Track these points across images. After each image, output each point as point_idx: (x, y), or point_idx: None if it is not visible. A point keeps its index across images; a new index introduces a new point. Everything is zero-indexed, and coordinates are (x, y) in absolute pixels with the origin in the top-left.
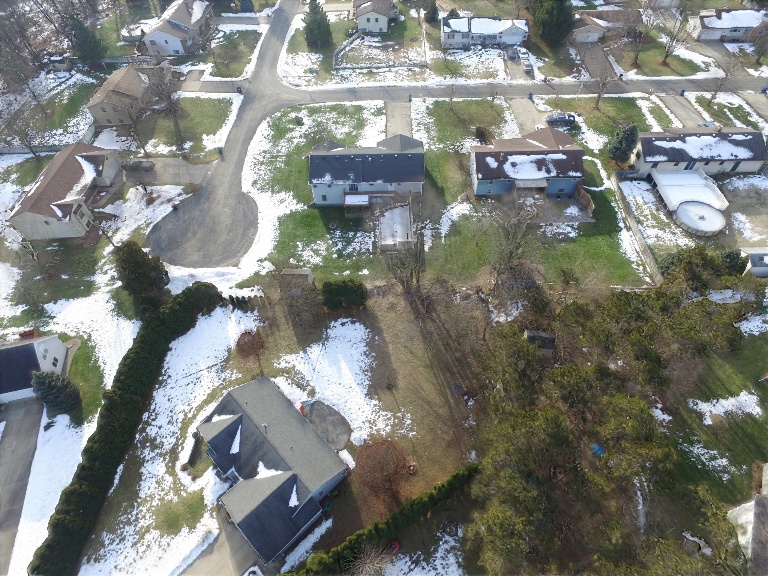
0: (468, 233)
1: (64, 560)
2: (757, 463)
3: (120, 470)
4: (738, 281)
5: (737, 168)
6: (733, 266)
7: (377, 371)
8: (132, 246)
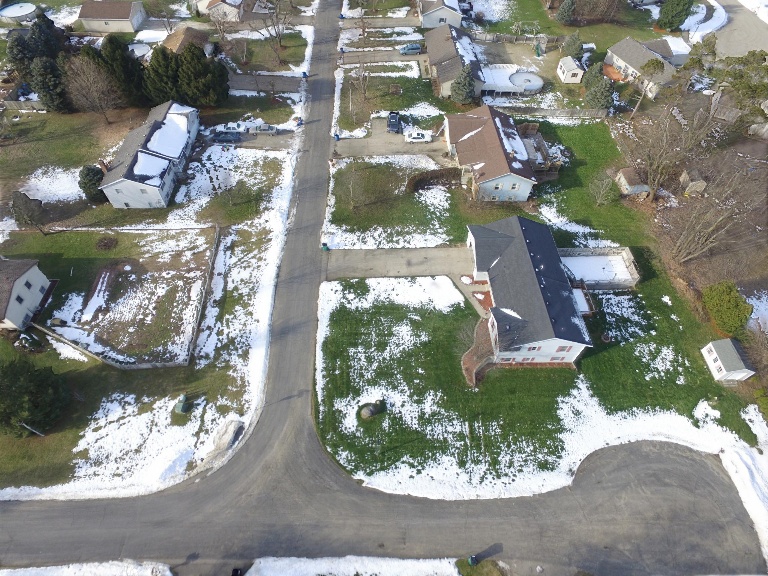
0: None
1: None
2: None
3: None
4: None
5: None
6: None
7: None
8: None
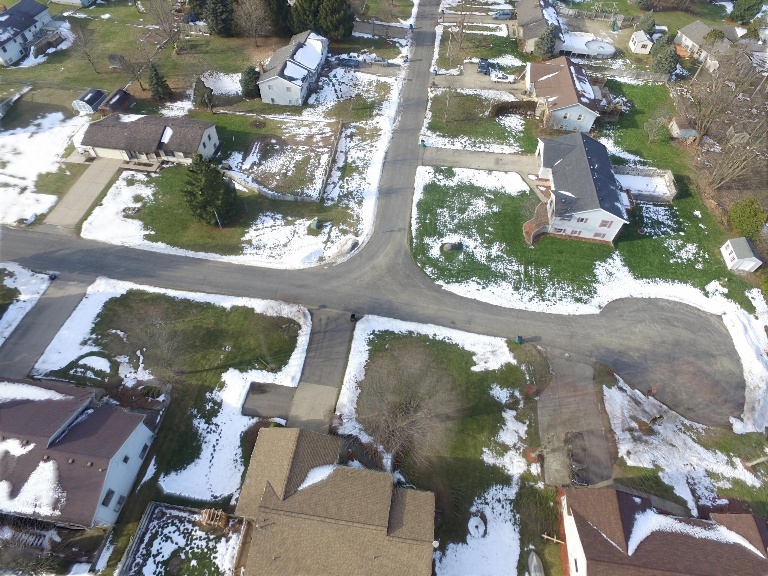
0: None
1: None
2: (765, 93)
3: None
4: None
5: None
6: None
7: None
8: None
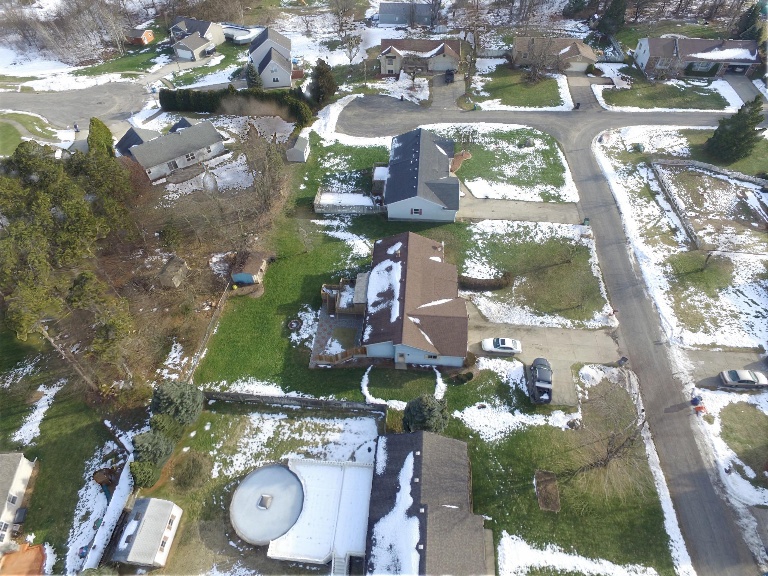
0: None
1: (166, 101)
2: None
3: (206, 113)
4: None
5: None
6: None
7: None
8: (325, 67)
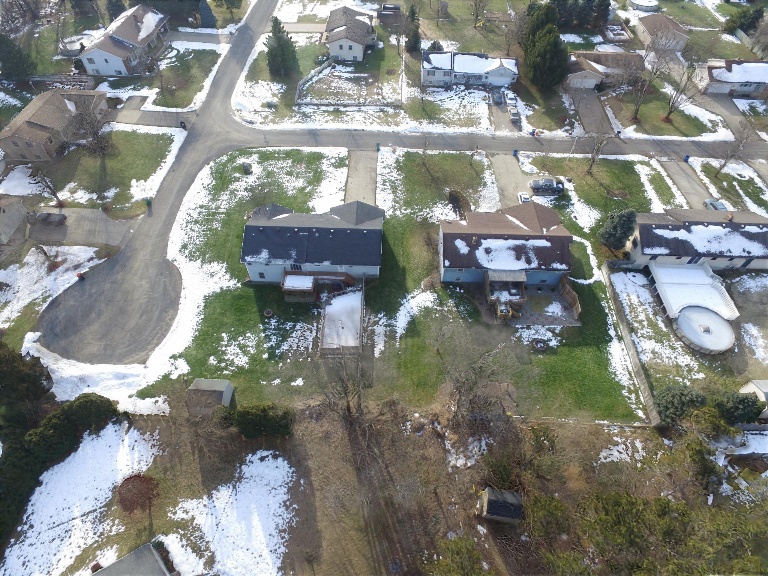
0: (428, 335)
1: None
2: None
3: None
4: (765, 490)
5: (749, 264)
6: (746, 413)
7: (297, 533)
8: None
